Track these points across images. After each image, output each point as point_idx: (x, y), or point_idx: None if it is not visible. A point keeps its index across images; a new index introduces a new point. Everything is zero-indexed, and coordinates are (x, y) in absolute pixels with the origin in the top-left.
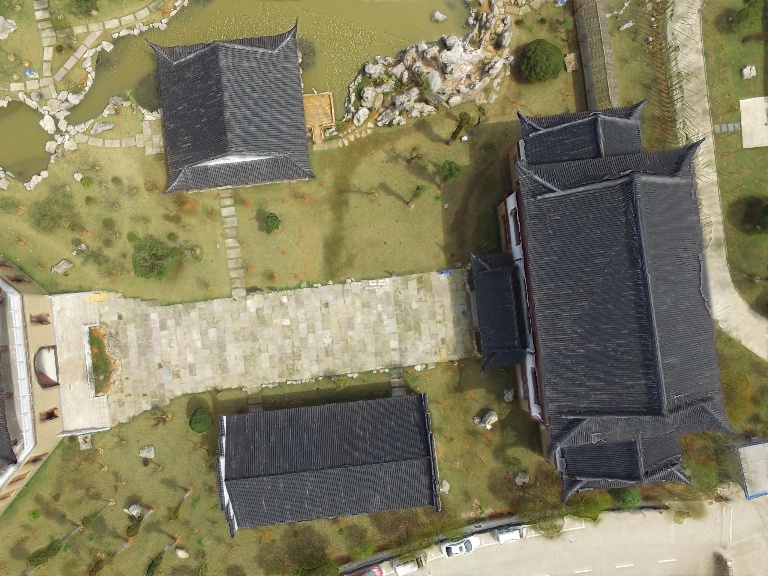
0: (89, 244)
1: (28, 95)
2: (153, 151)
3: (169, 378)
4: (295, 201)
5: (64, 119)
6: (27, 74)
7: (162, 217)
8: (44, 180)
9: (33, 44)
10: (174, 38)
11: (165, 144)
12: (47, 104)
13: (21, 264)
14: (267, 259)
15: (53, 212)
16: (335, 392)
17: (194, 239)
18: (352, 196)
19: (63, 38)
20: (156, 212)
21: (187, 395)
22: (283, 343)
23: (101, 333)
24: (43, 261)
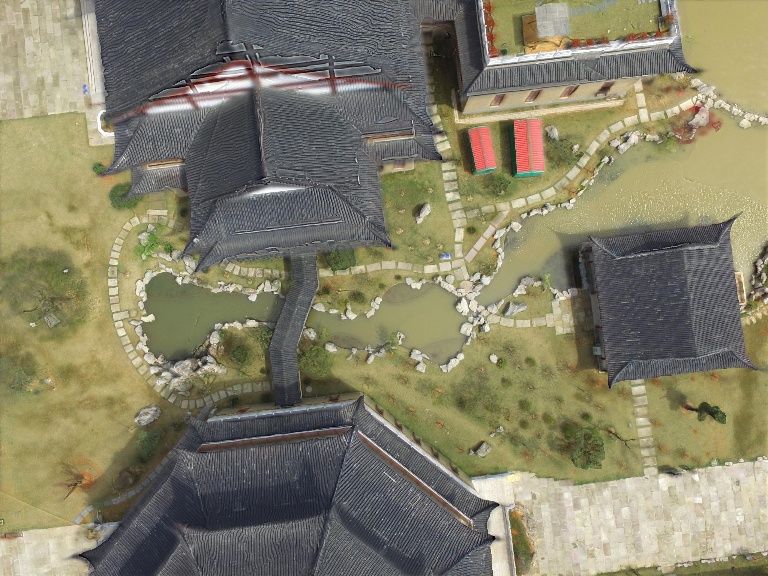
0: (506, 426)
1: (443, 278)
2: (564, 331)
3: (584, 558)
4: (705, 379)
5: (474, 299)
6: (443, 257)
7: (574, 397)
8: (460, 362)
9: (445, 226)
10: (581, 217)
11: (575, 324)
12: (460, 286)
13: (439, 446)
14: (679, 438)
15: (486, 401)
16: (750, 571)
17: (607, 419)
18: (762, 374)
19: (472, 219)
20: (568, 392)
21: (602, 575)
22: (696, 522)
23: (519, 514)
24: (461, 443)
